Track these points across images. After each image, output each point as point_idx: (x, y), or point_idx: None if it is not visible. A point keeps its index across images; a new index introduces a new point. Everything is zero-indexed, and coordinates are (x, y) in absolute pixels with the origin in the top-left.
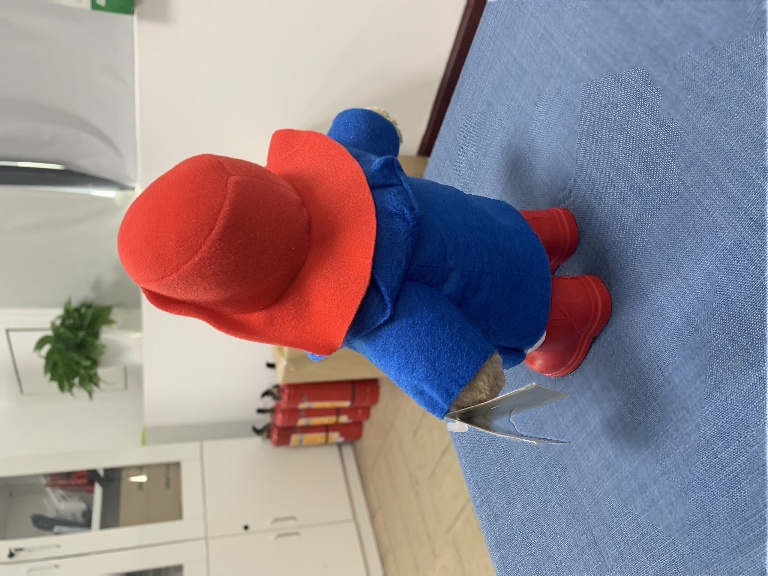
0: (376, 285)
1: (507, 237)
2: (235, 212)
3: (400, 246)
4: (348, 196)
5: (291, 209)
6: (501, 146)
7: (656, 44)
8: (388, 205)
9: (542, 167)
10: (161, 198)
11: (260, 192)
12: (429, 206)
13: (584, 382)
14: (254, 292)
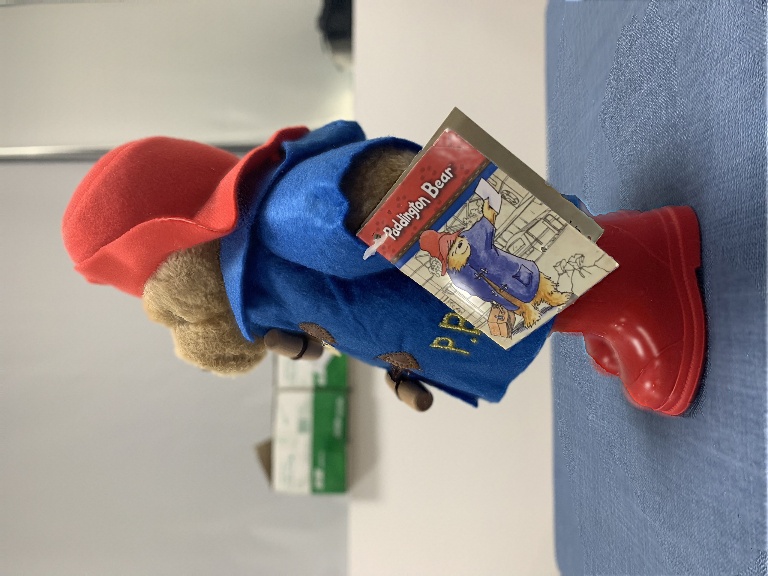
0: (280, 148)
1: None
2: None
3: (323, 134)
4: None
5: (223, 152)
6: None
7: (617, 3)
8: None
9: None
10: None
11: None
12: None
13: (721, 348)
14: (160, 204)
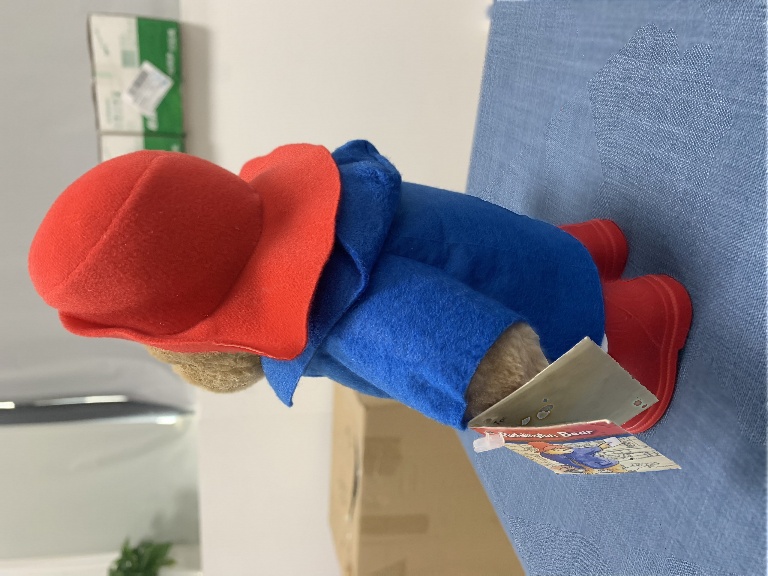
0: (344, 251)
1: (526, 223)
2: (157, 180)
3: (374, 209)
4: (307, 170)
5: (235, 187)
6: (519, 199)
7: None
8: (356, 171)
9: (566, 192)
10: (73, 184)
11: (194, 167)
12: (417, 191)
13: (684, 421)
14: (187, 285)
